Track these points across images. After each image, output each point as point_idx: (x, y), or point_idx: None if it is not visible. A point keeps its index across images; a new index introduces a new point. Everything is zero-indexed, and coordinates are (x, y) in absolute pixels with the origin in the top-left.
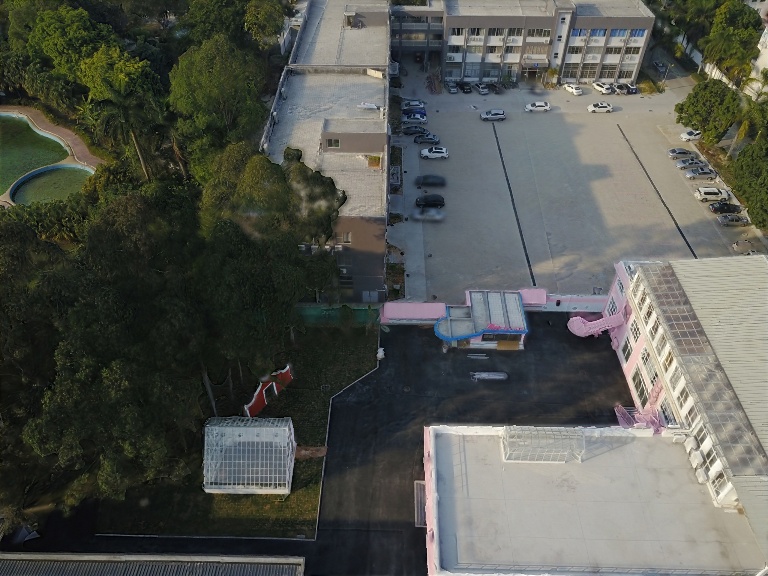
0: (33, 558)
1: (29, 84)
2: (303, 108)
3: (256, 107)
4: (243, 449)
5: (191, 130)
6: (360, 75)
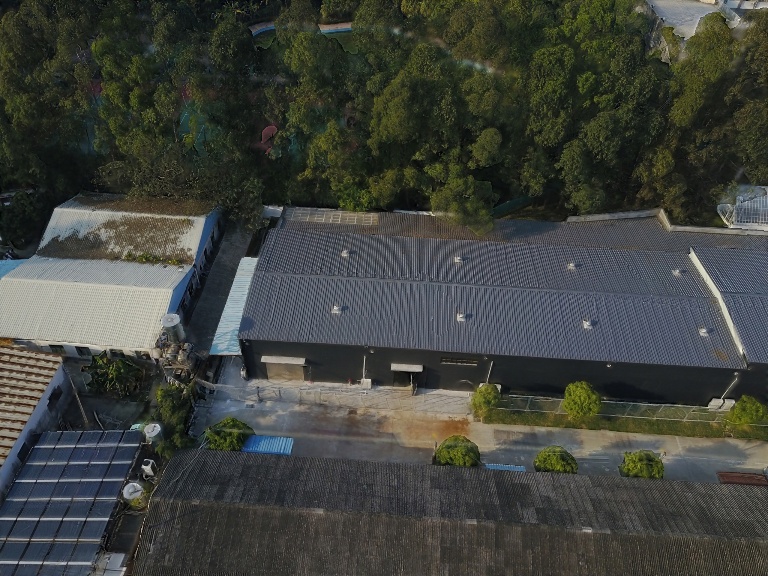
0: (691, 231)
1: (410, 3)
2: (672, 19)
3: (644, 15)
4: (759, 200)
5: (622, 23)
6: (693, 2)
